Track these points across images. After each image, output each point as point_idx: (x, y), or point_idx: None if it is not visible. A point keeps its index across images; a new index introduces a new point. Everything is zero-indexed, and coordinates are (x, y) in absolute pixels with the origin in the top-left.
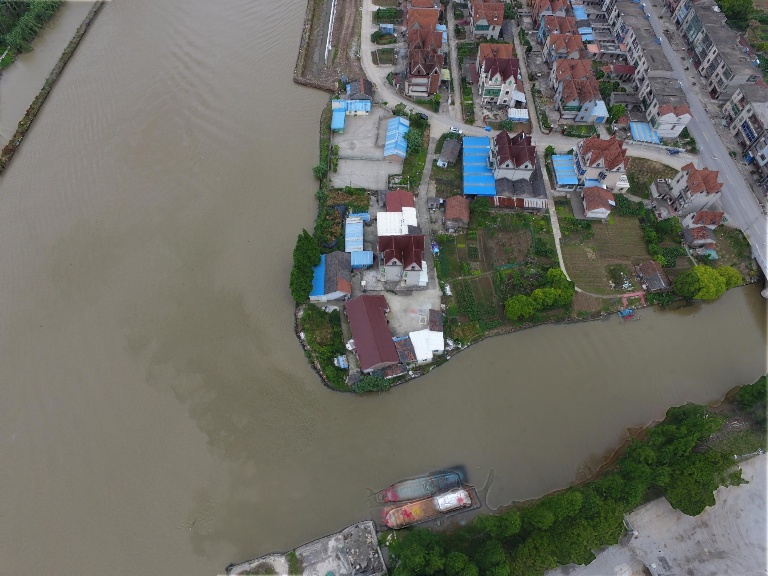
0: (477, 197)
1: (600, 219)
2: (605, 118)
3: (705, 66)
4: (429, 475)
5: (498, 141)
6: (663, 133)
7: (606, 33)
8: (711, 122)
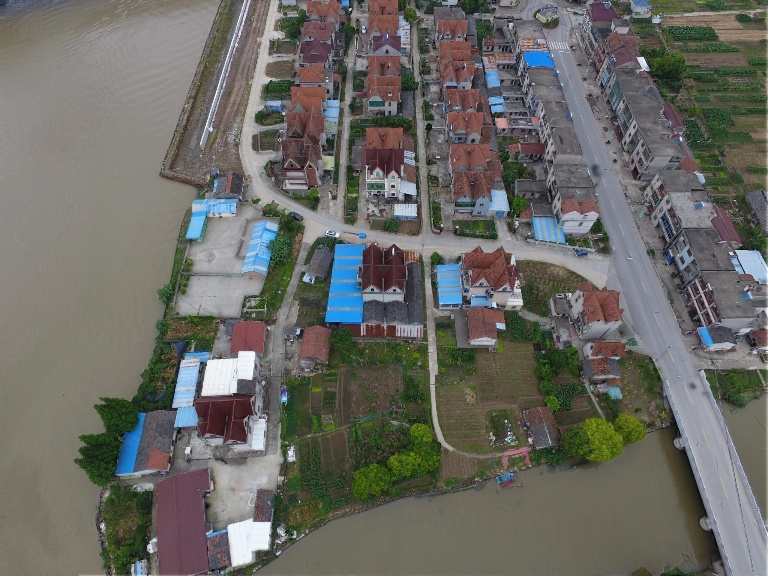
0: (341, 325)
1: (487, 347)
2: (506, 212)
3: (627, 140)
4: None
5: (365, 257)
6: (571, 229)
7: (518, 103)
8: (630, 210)
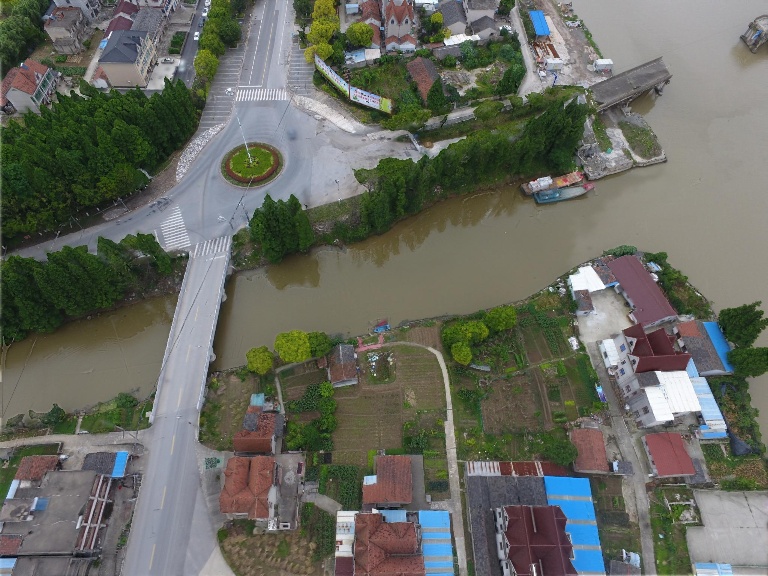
0: None
1: None
2: None
3: None
4: (557, 202)
5: (570, 567)
6: None
7: None
8: None
